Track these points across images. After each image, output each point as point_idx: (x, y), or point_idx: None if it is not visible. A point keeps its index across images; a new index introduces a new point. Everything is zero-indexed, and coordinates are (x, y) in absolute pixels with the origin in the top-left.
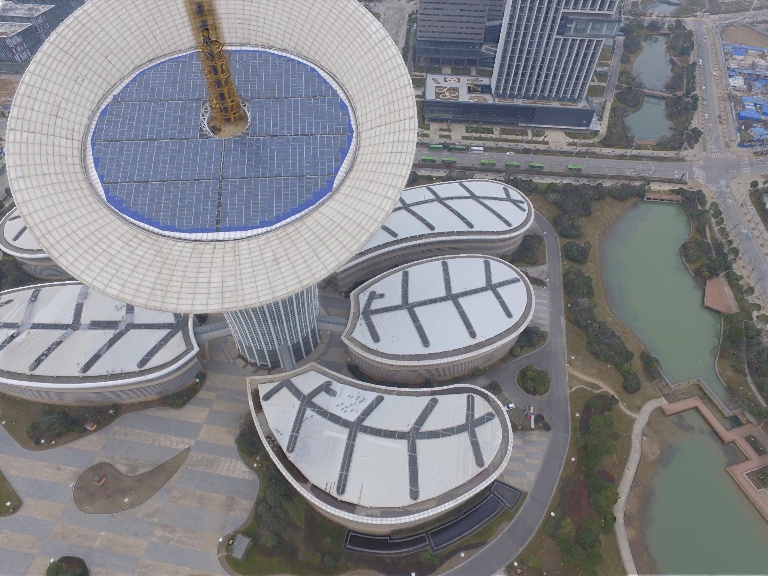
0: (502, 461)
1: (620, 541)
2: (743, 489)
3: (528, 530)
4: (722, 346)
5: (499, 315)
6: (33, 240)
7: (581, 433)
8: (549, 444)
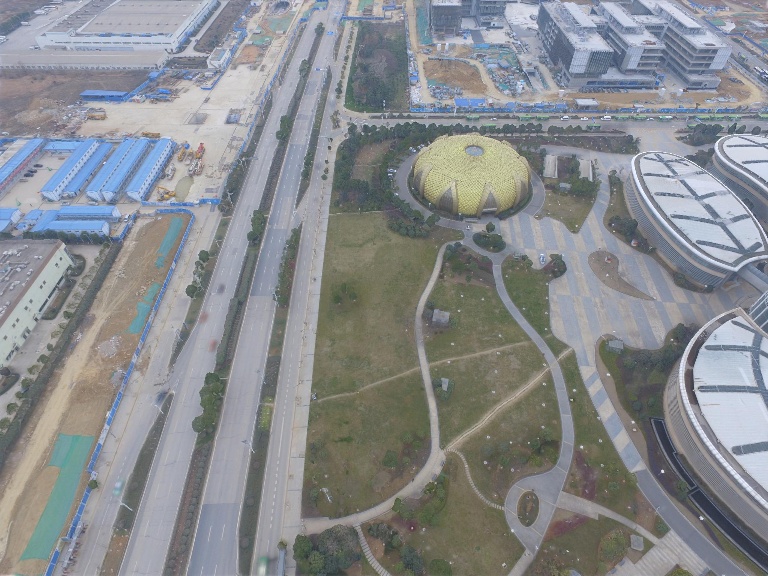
0: None
1: None
2: None
3: None
4: None
5: None
6: (737, 153)
7: None
8: None
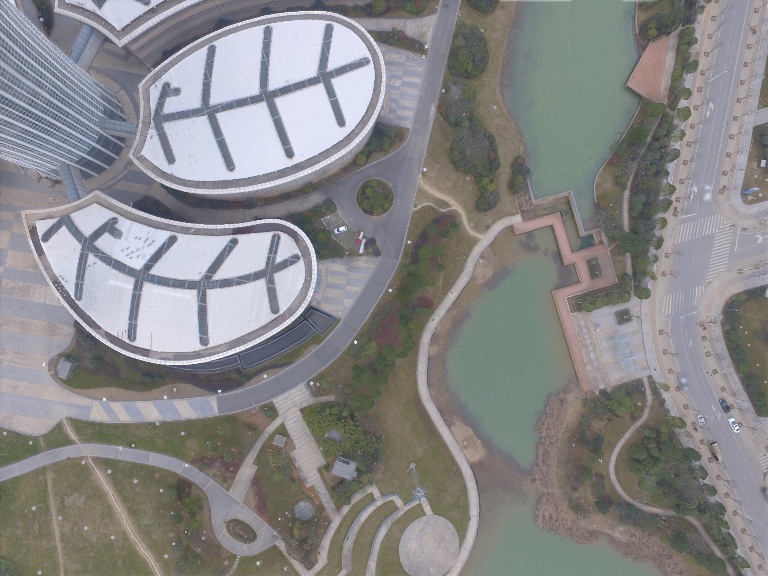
0: (299, 307)
1: (420, 357)
2: (558, 311)
3: (334, 352)
4: (617, 149)
5: (327, 123)
6: None
7: (411, 259)
8: (374, 270)
